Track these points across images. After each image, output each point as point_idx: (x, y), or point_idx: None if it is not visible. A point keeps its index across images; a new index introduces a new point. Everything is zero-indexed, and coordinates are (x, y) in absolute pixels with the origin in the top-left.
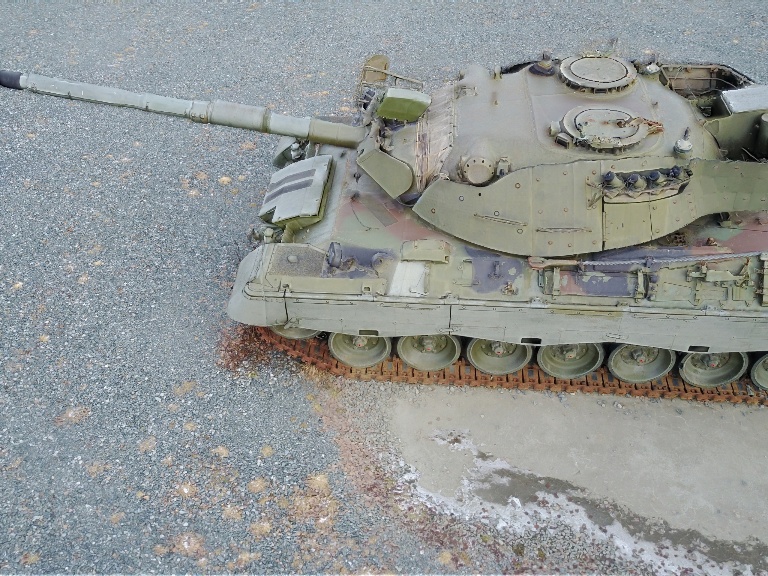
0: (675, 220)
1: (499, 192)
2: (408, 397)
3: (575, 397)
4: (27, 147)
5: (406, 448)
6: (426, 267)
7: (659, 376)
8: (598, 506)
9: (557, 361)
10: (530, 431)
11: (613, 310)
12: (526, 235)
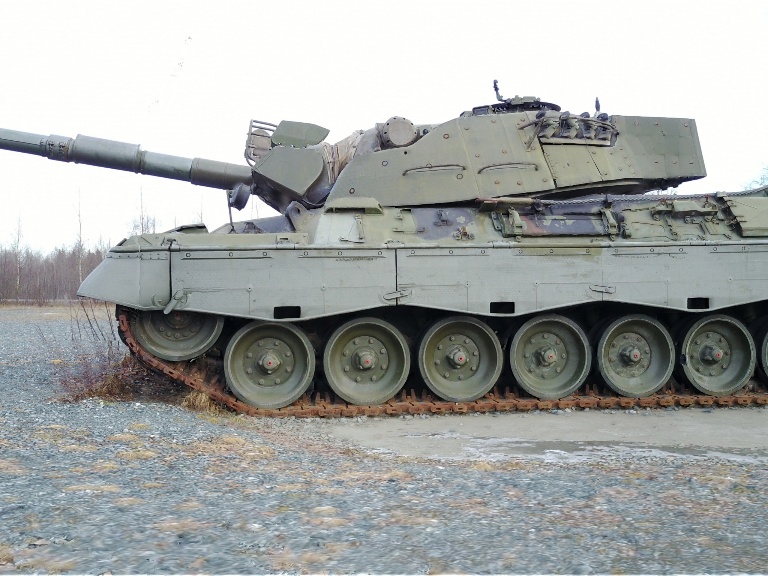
0: (618, 169)
1: (427, 146)
2: (348, 424)
3: (573, 413)
4: None
5: (364, 442)
6: (356, 217)
7: (663, 381)
8: (674, 447)
9: (534, 380)
10: (534, 426)
11: (589, 245)
12: (467, 179)
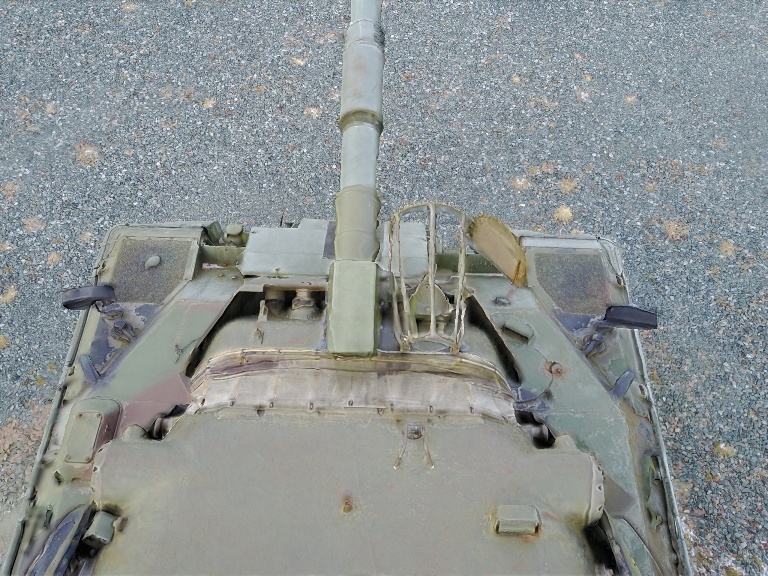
0: None
1: None
2: None
3: None
4: (584, 1)
5: None
6: None
7: None
8: None
9: None
10: None
11: None
12: None
